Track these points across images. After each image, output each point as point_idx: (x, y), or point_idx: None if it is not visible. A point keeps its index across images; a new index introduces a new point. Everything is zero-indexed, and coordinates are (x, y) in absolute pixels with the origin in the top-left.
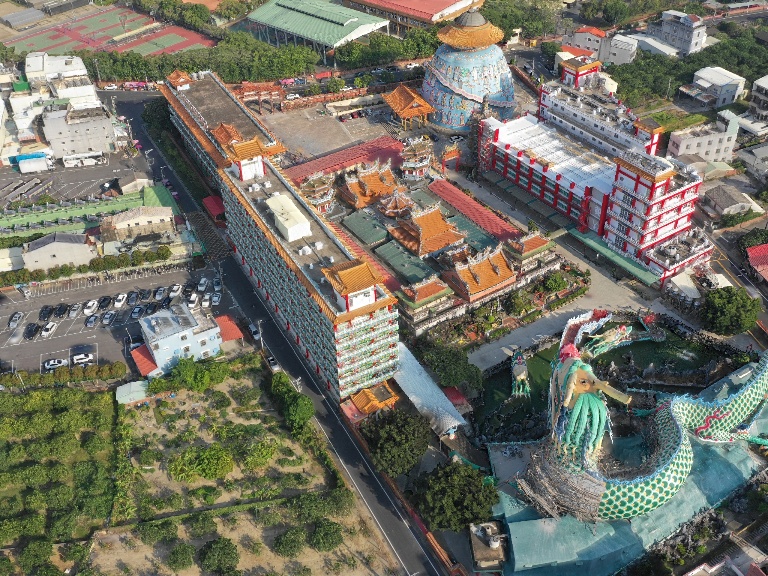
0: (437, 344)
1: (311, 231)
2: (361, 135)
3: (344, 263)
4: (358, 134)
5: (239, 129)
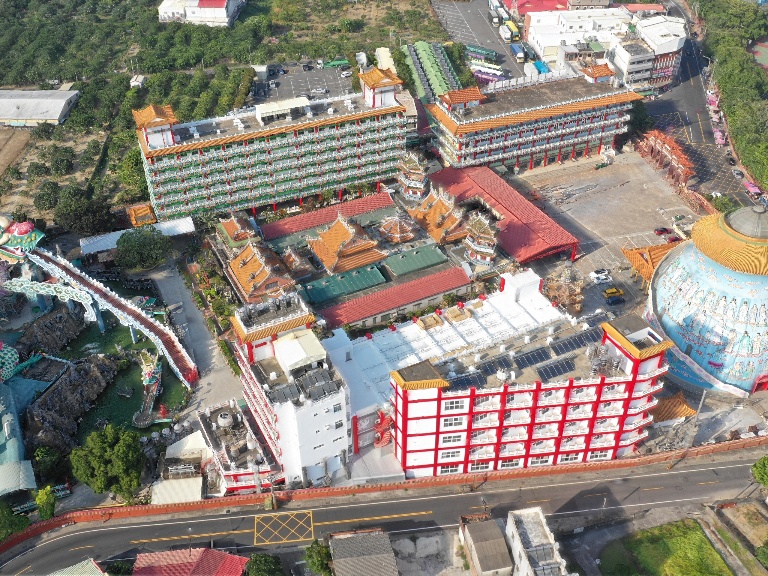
0: (168, 235)
1: (268, 126)
2: (621, 244)
3: None
4: (623, 242)
5: (495, 108)
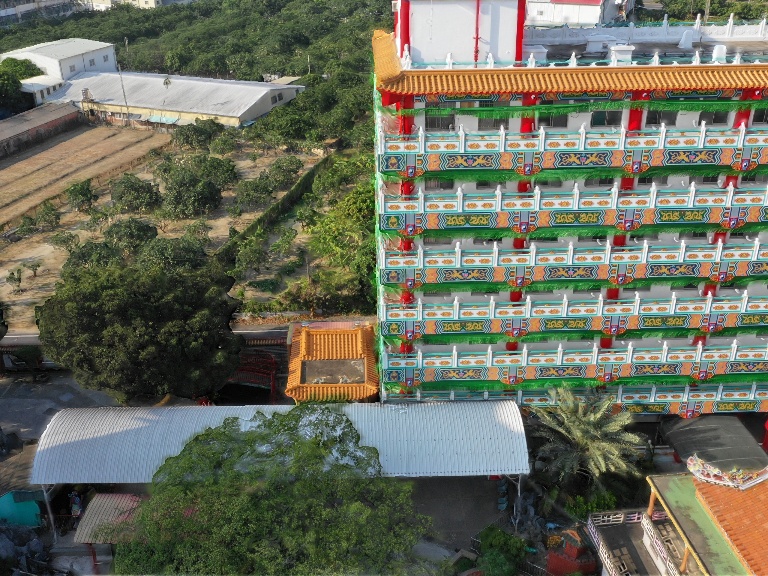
0: None
1: None
2: None
3: None
4: None
5: None
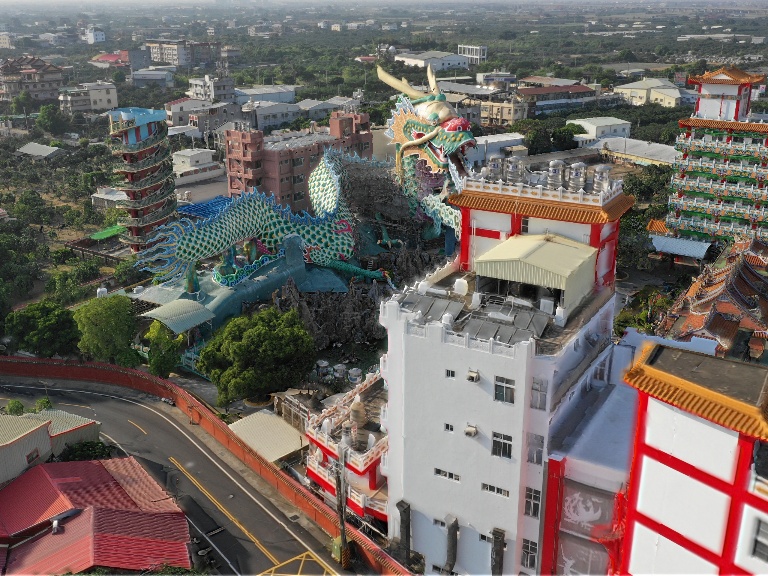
0: None
1: None
2: None
3: (755, 81)
4: None
5: None
